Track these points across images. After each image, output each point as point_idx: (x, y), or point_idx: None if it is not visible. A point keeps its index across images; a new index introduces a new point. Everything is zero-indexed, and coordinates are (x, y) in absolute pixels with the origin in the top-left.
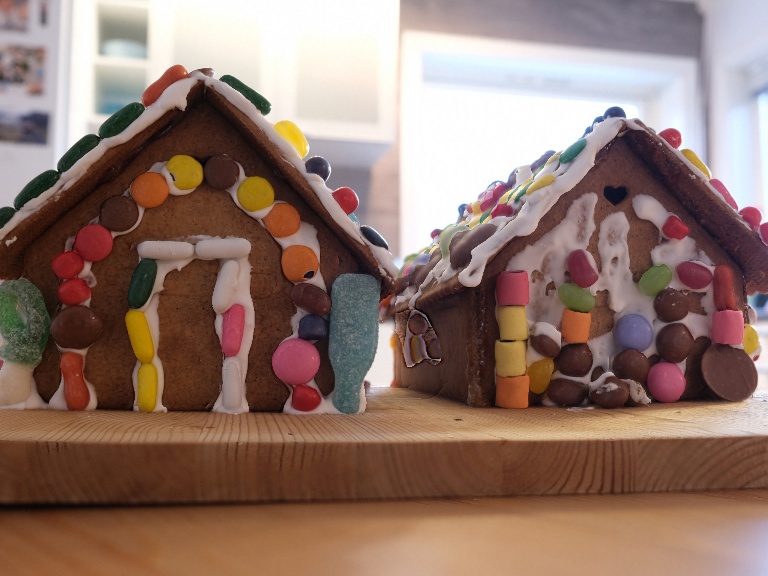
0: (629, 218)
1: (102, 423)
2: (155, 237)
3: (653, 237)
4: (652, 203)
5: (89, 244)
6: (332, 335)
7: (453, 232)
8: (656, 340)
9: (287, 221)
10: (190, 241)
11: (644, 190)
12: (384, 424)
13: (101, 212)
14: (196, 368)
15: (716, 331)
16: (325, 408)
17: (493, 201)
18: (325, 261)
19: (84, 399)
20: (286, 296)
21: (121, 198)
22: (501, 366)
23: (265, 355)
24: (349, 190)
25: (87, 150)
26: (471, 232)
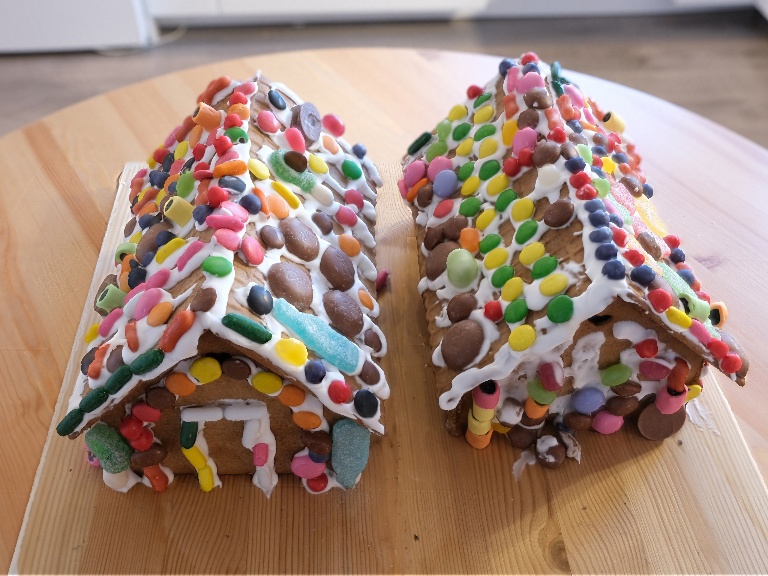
0: (607, 334)
1: (183, 573)
2: (192, 402)
3: (626, 344)
4: (631, 329)
5: (143, 417)
6: (333, 459)
7: (457, 272)
8: (607, 402)
9: (294, 401)
10: (219, 402)
11: (628, 317)
12: (361, 566)
13: (147, 400)
14: (238, 461)
15: (660, 401)
16: (331, 485)
17: (517, 166)
18: (327, 410)
19: (165, 486)
20: (298, 428)
21: (159, 393)
22: (471, 428)
23: (286, 455)
24: (343, 388)
25: (125, 382)
26: (459, 344)
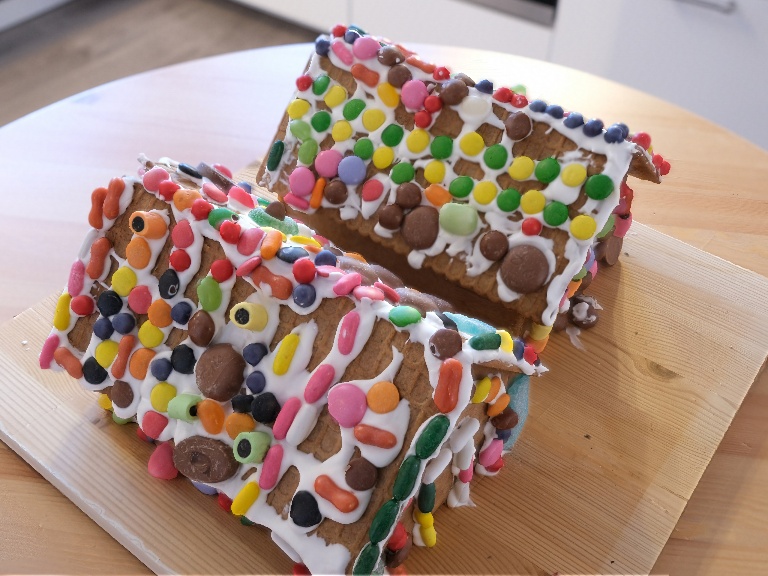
0: None
1: None
2: None
3: None
4: None
5: None
6: None
7: (467, 222)
8: None
9: None
10: None
11: None
12: (586, 485)
13: None
14: None
15: (617, 230)
16: None
17: (429, 116)
18: None
19: None
20: None
21: None
22: (539, 337)
23: None
24: None
25: None
26: (531, 268)
